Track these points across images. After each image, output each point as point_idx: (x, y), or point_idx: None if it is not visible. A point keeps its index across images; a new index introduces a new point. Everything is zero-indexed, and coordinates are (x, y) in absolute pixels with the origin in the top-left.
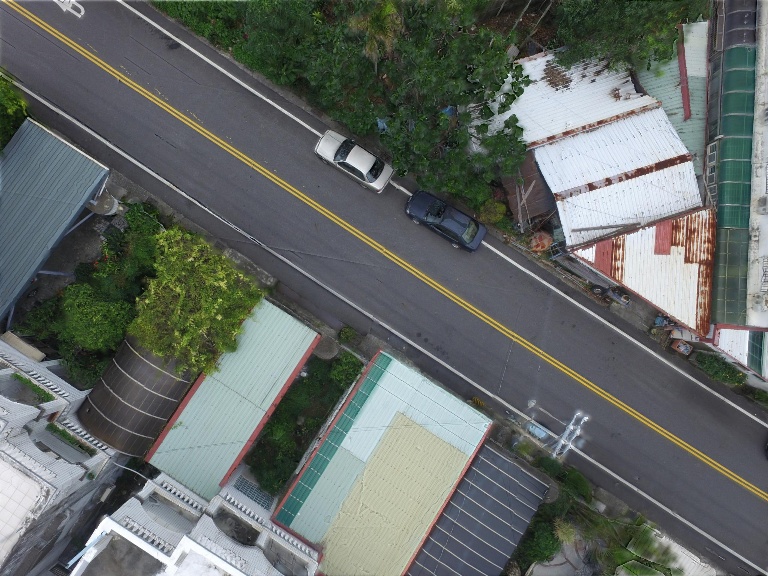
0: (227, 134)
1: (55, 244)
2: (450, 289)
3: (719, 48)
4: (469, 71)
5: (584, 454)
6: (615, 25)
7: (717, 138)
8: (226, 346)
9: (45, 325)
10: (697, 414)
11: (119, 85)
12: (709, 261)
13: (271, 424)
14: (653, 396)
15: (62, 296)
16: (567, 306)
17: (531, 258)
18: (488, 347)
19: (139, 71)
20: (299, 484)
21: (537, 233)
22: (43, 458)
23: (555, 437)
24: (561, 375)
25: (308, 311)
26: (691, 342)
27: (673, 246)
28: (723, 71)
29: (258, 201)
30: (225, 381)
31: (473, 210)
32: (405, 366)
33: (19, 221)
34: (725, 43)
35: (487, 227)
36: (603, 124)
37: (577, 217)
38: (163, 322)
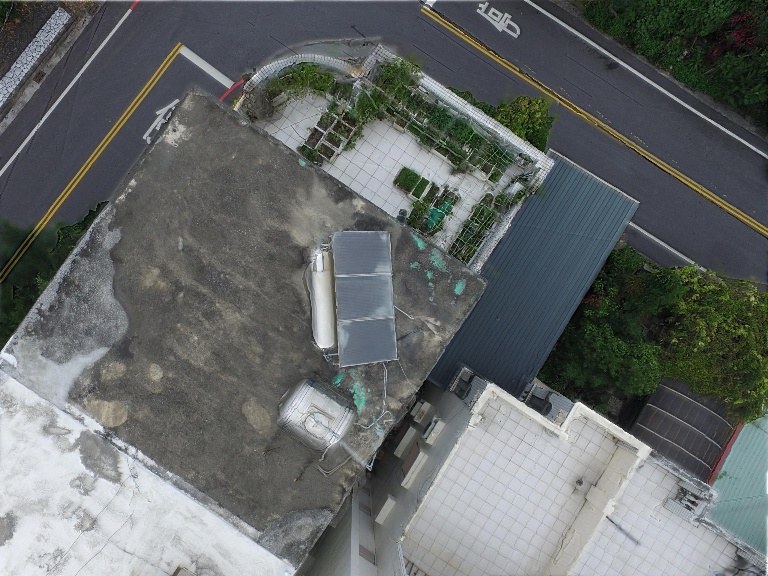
0: (673, 158)
1: None
2: None
3: None
4: None
5: None
6: None
7: None
8: None
9: None
10: None
11: (559, 108)
12: None
13: None
14: None
15: None
16: None
17: None
18: None
19: (579, 93)
20: None
21: None
22: None
23: None
24: None
25: None
26: None
27: None
28: None
29: (707, 228)
30: (764, 427)
31: None
32: None
33: (552, 259)
34: None
35: None
36: None
37: None
38: (730, 367)
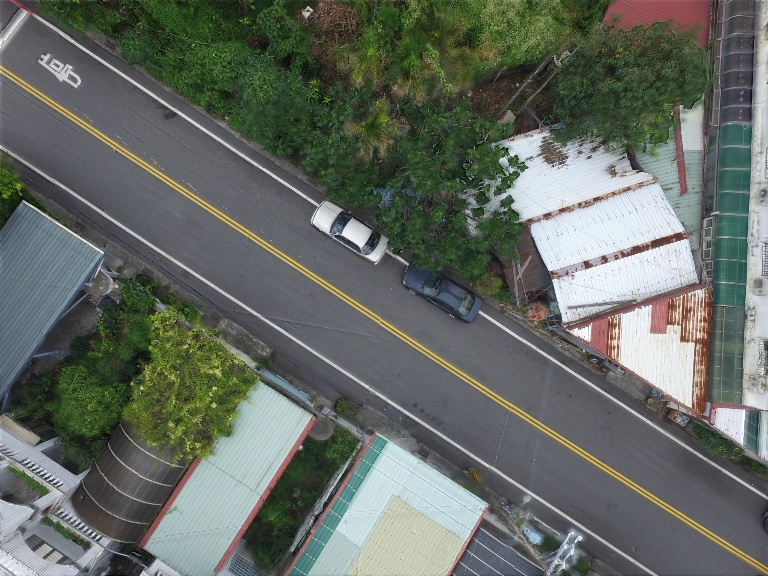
0: (223, 204)
1: (50, 329)
2: (446, 359)
3: (715, 123)
4: (464, 159)
5: (580, 525)
6: (610, 113)
7: (713, 214)
8: (221, 432)
9: (40, 403)
10: (694, 484)
11: (115, 155)
12: (705, 340)
13: (266, 503)
14: (650, 466)
15: (57, 371)
16: (563, 375)
17: (527, 327)
18: (484, 417)
19: (135, 141)
20: (294, 570)
21: (533, 304)
22: (36, 563)
23: (551, 508)
24: (557, 446)
25: (304, 381)
26: (687, 414)
27: (669, 325)
28: (719, 147)
29: (254, 271)
30: (220, 465)
31: (469, 279)
32: (401, 448)
33: (14, 306)
34: (721, 119)
35: (483, 296)
36: (599, 200)
37: (573, 294)
38: (158, 410)
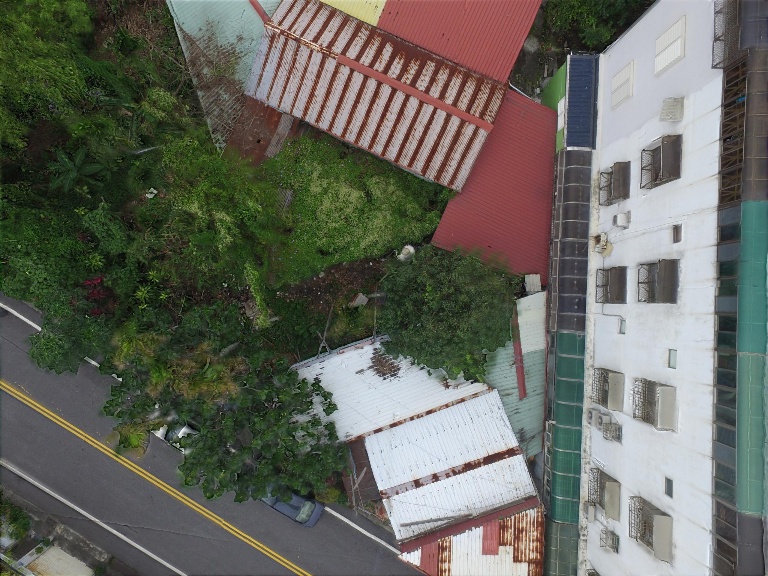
0: (57, 406)
1: None
2: (292, 560)
3: (553, 328)
4: None
5: None
6: None
7: (551, 423)
8: None
9: None
10: None
11: None
12: (538, 560)
13: None
14: None
15: None
16: (414, 571)
17: (377, 521)
18: None
19: None
20: None
21: (379, 503)
22: None
23: None
24: None
25: None
26: None
27: (501, 546)
28: (556, 353)
29: (91, 474)
30: None
31: None
32: None
33: None
34: (558, 324)
35: None
36: None
37: (405, 513)
38: None
